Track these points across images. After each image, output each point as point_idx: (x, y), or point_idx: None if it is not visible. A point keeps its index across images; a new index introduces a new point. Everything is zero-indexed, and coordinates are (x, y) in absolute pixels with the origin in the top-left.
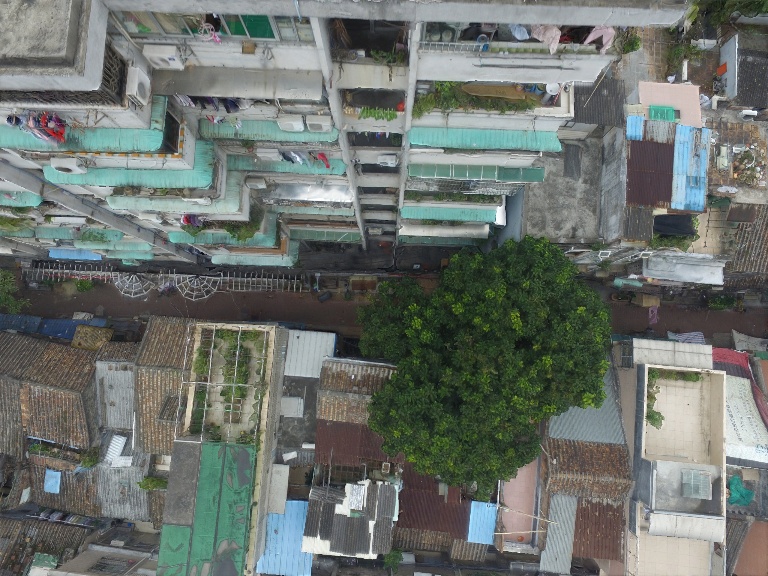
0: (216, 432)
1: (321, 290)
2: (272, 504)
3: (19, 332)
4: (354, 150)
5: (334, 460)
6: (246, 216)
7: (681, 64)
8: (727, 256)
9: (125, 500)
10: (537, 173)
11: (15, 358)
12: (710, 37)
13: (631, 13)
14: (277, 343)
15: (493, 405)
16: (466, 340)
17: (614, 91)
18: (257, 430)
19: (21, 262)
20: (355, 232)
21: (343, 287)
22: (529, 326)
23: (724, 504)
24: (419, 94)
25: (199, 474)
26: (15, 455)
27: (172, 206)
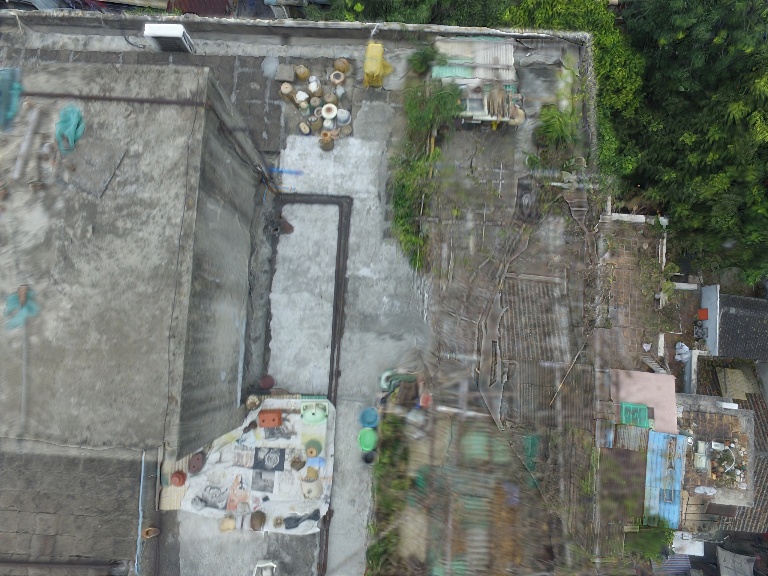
0: None
1: None
2: None
3: None
4: None
5: None
6: None
7: (657, 336)
8: (707, 535)
9: None
10: None
11: None
12: (691, 274)
13: None
14: None
15: None
16: None
17: (583, 382)
18: None
19: None
20: None
21: None
22: None
23: None
24: None
25: None
26: None
27: None
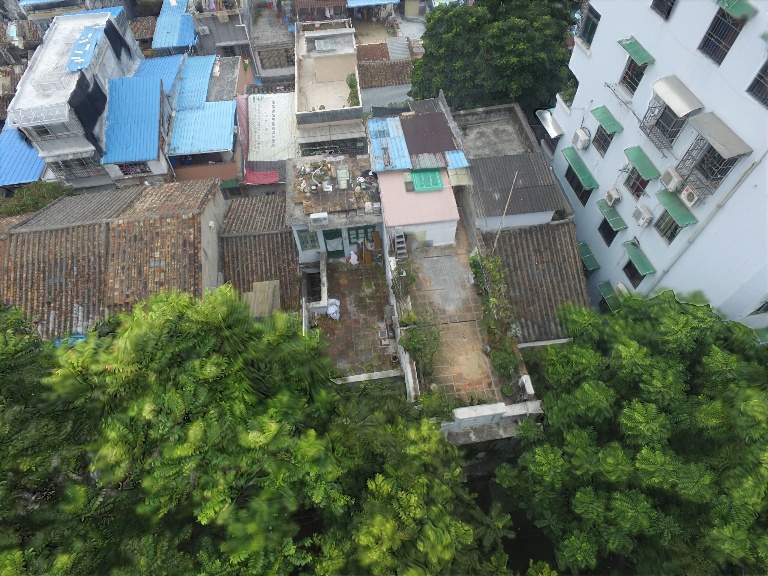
0: None
1: None
2: None
3: None
4: None
5: None
6: None
7: None
8: None
9: None
10: None
11: None
12: None
13: None
14: None
15: None
16: None
17: (487, 200)
18: None
19: None
20: None
21: None
22: None
23: (296, 57)
24: None
25: None
26: None
27: None
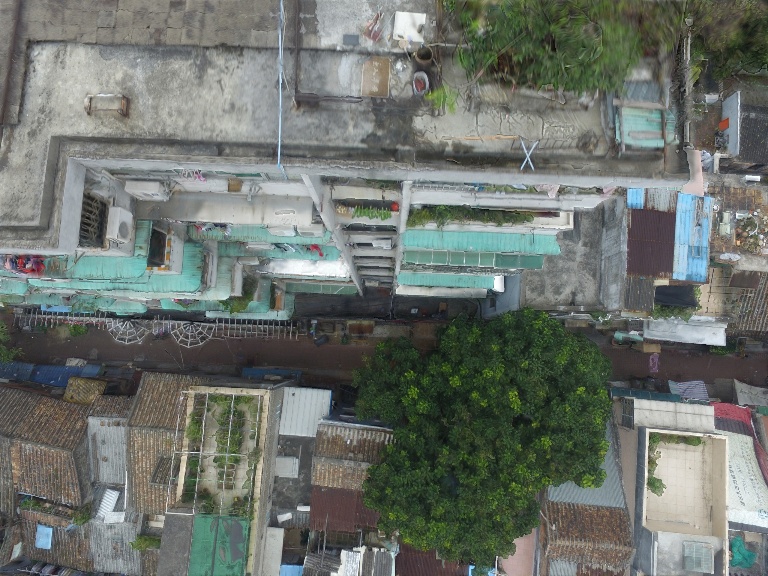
0: None
1: (318, 333)
2: (266, 569)
3: (11, 381)
4: (348, 235)
5: (329, 526)
6: (239, 292)
7: (683, 125)
8: (729, 319)
9: (118, 555)
10: (536, 260)
11: (6, 414)
12: (712, 91)
13: (633, 181)
14: (271, 406)
15: (491, 492)
16: (463, 417)
17: None
18: (251, 498)
19: (14, 308)
20: (351, 286)
21: (340, 330)
22: (528, 405)
23: (726, 574)
24: (413, 208)
25: (191, 548)
26: (6, 511)
27: (162, 294)
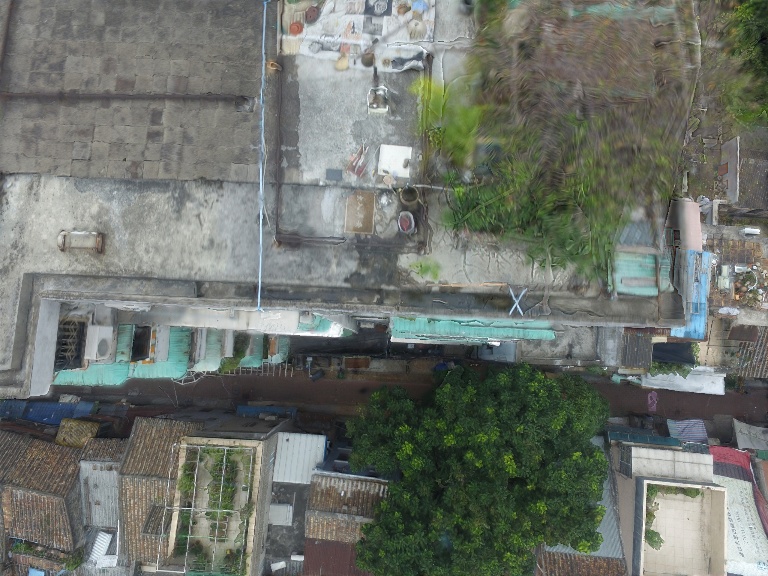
0: (201, 551)
1: (313, 368)
2: None
3: (3, 419)
4: None
5: None
6: (230, 354)
7: (681, 174)
8: (728, 369)
9: None
10: None
11: None
12: (711, 134)
13: None
14: (265, 456)
15: (485, 563)
16: (458, 479)
17: None
18: (243, 552)
19: None
20: None
21: (336, 365)
22: (523, 468)
23: None
24: None
25: None
26: None
27: None
